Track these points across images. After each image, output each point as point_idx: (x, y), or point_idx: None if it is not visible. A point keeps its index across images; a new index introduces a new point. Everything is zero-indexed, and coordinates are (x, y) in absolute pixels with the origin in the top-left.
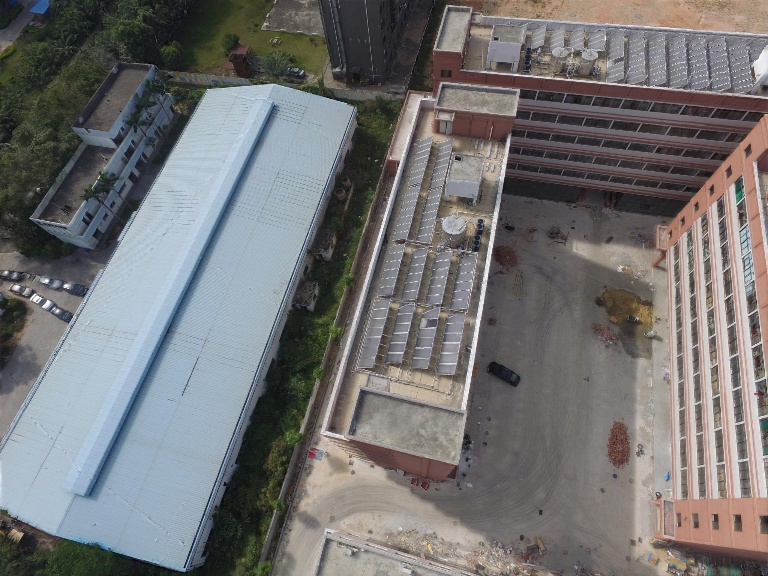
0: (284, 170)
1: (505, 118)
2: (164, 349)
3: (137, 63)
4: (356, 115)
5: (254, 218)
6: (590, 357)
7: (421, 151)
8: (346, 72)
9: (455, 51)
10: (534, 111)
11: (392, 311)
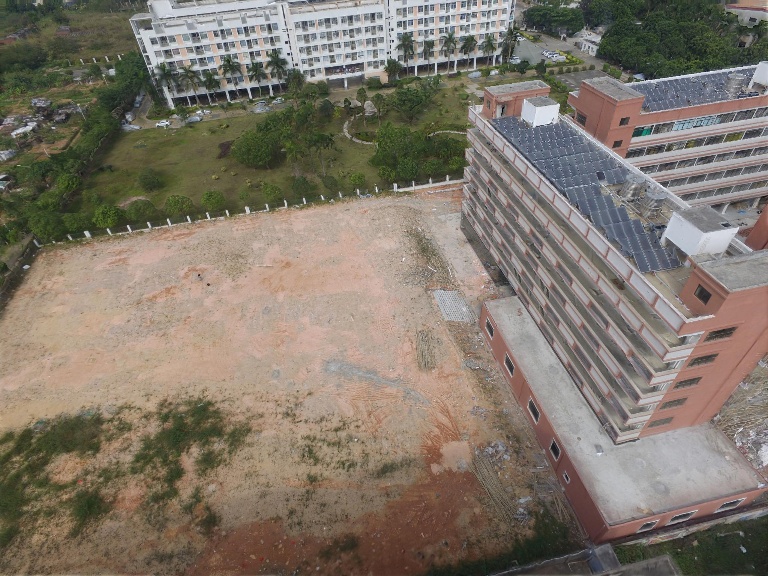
0: None
1: None
2: None
3: None
4: None
5: None
6: None
7: None
8: None
9: None
10: None
11: None
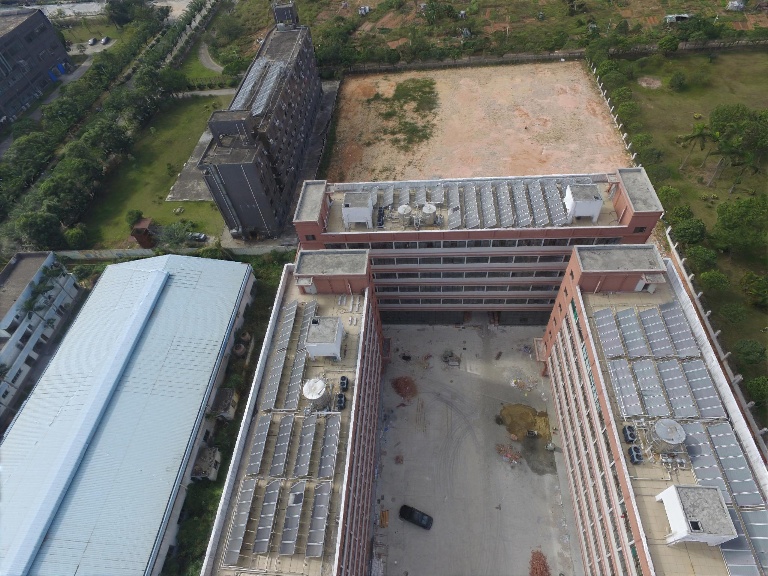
0: (179, 337)
1: (358, 276)
2: (39, 563)
3: (36, 252)
4: (252, 271)
5: (147, 392)
6: (498, 482)
7: (288, 314)
8: (242, 232)
9: (312, 220)
10: (396, 257)
11: (261, 490)
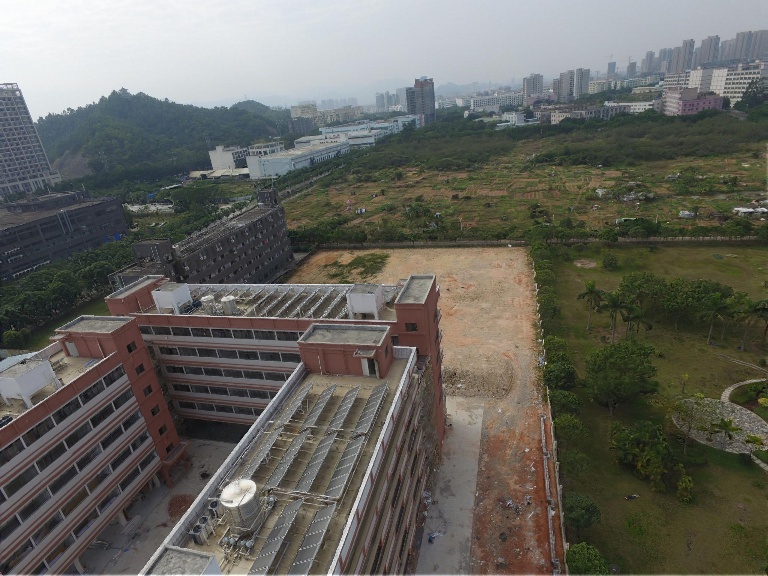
0: None
1: (105, 336)
2: None
3: None
4: None
5: None
6: None
7: None
8: None
9: (119, 298)
10: (197, 347)
11: None
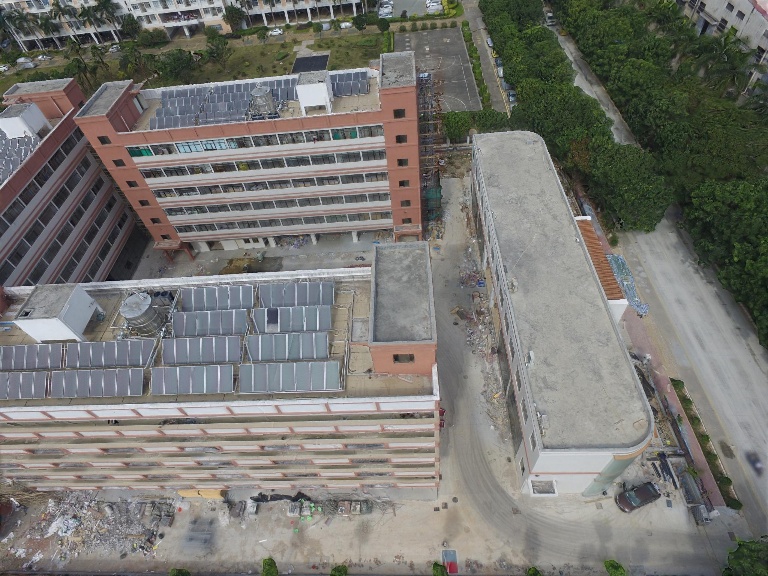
0: None
1: None
2: None
3: None
4: None
5: None
6: None
7: None
8: None
9: None
10: None
11: None
